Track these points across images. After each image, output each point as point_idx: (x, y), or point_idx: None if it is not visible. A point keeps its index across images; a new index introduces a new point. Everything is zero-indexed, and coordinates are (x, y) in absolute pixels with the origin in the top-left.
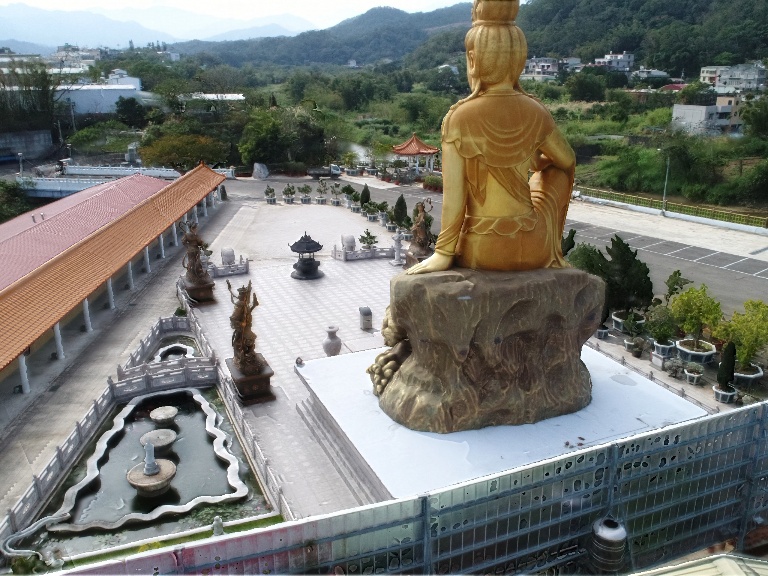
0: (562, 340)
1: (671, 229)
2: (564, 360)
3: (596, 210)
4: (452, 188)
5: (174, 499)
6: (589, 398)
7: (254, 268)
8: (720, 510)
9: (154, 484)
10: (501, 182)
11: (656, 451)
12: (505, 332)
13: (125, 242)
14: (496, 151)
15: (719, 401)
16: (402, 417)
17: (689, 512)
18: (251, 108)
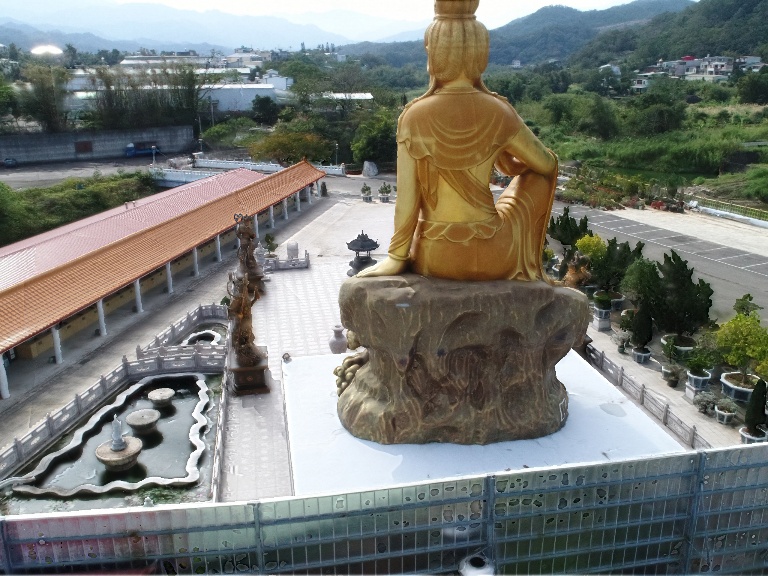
0: (522, 359)
1: None
2: (522, 380)
3: (710, 223)
4: (403, 190)
5: (138, 476)
6: (558, 425)
7: (319, 263)
8: (649, 567)
9: (115, 459)
10: (453, 185)
11: (551, 490)
12: (451, 344)
13: (193, 231)
14: (446, 152)
15: None
16: (347, 422)
17: (605, 564)
18: (379, 107)
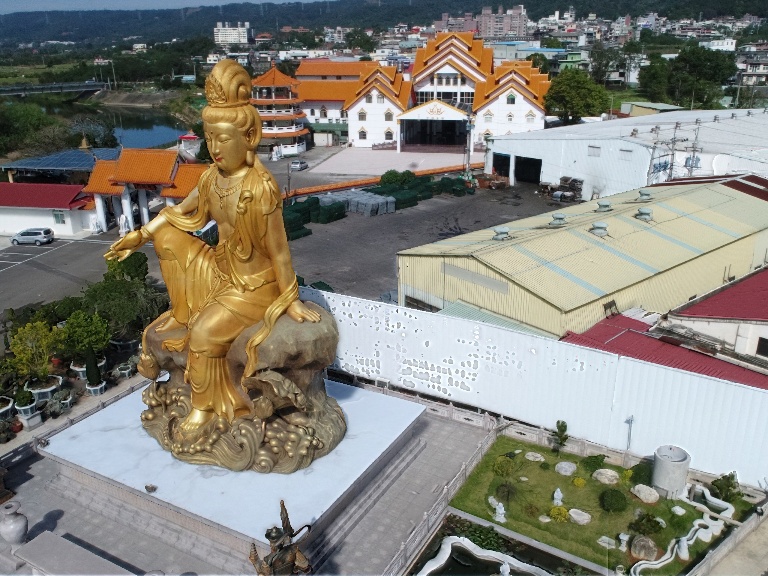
0: None
1: None
2: None
3: None
4: None
5: None
6: None
7: None
8: None
9: None
10: None
11: None
12: None
13: None
14: None
15: (104, 393)
16: None
17: None
18: None
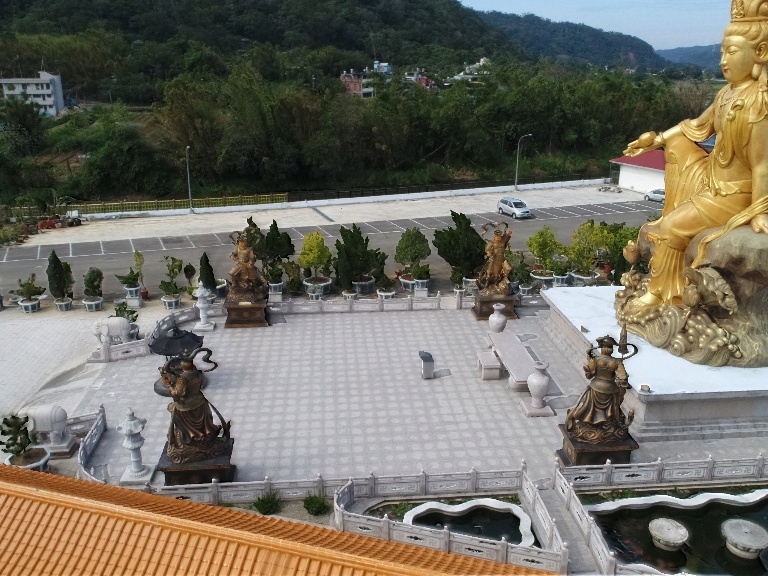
0: None
1: (236, 221)
2: None
3: (132, 224)
4: None
5: None
6: None
7: None
8: None
9: None
10: None
11: None
12: None
13: None
14: None
15: None
16: None
17: None
18: None
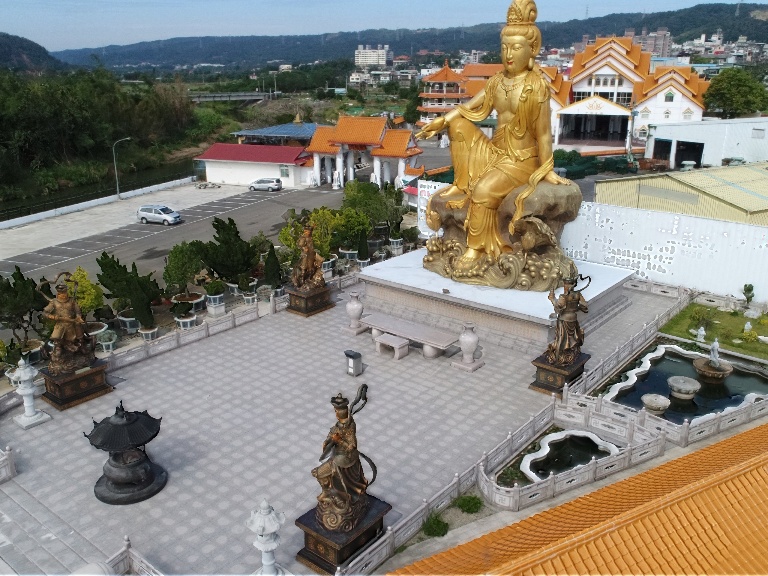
0: None
1: None
2: None
3: None
4: None
5: None
6: None
7: None
8: None
9: None
10: None
11: None
12: None
13: None
14: None
15: None
16: None
17: None
18: None
